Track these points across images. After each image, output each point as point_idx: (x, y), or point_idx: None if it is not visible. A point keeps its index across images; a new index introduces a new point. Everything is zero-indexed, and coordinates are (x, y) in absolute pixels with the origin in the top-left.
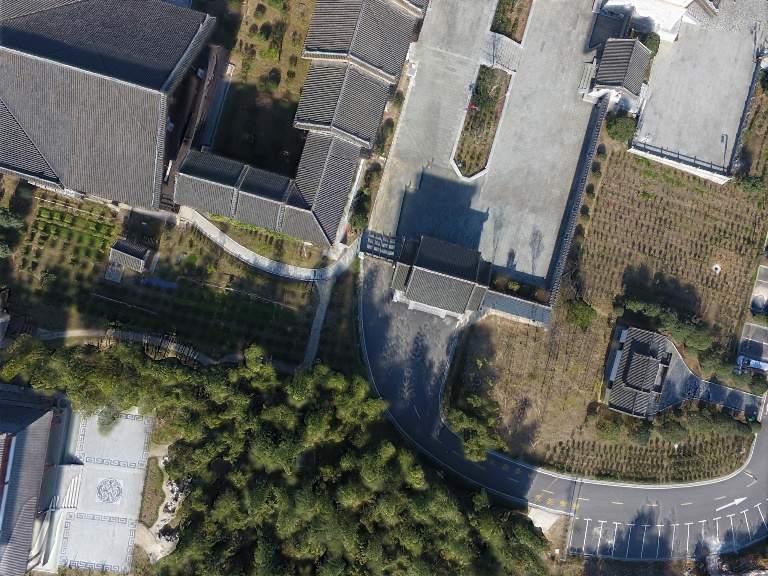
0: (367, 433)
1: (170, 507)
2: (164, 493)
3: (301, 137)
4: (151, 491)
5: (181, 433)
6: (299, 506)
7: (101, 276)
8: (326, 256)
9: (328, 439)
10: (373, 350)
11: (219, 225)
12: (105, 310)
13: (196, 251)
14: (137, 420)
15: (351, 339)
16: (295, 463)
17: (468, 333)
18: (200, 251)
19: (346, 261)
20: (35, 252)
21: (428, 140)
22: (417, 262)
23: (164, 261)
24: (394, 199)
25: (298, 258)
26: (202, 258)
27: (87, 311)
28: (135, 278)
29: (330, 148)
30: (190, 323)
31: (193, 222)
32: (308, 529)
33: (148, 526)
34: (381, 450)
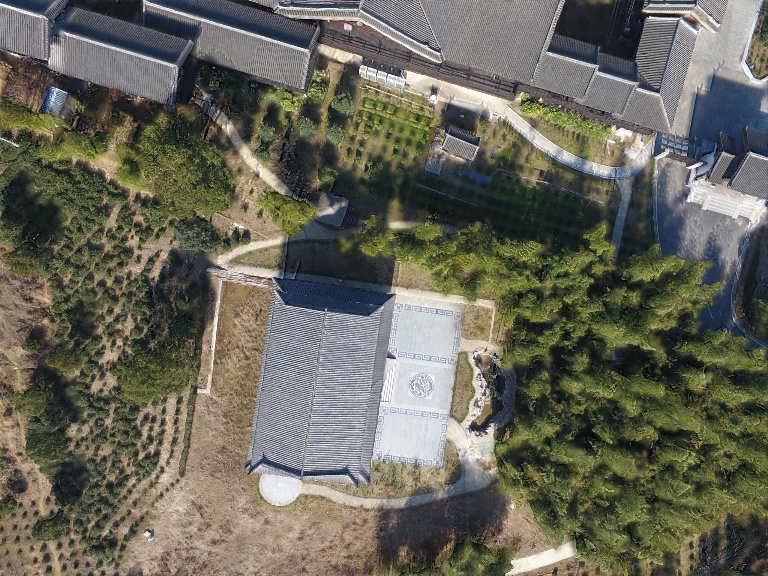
0: (699, 319)
1: (480, 402)
2: (474, 388)
3: (604, 35)
4: (462, 386)
5: (529, 315)
6: (650, 386)
7: (421, 168)
8: (627, 154)
9: (654, 328)
10: (667, 250)
11: (529, 120)
12: (425, 202)
13: (509, 145)
14: (447, 315)
15: (648, 238)
16: (611, 355)
17: (759, 233)
18: (513, 145)
19: (642, 161)
20: (359, 142)
21: (719, 42)
22: (750, 149)
23: (481, 154)
24: (687, 100)
25: (602, 155)
26: (514, 152)
27: (410, 202)
28: (453, 170)
29: (677, 32)
30: (504, 217)
31: (505, 117)
32: (653, 411)
33: (459, 421)
34: (716, 335)
